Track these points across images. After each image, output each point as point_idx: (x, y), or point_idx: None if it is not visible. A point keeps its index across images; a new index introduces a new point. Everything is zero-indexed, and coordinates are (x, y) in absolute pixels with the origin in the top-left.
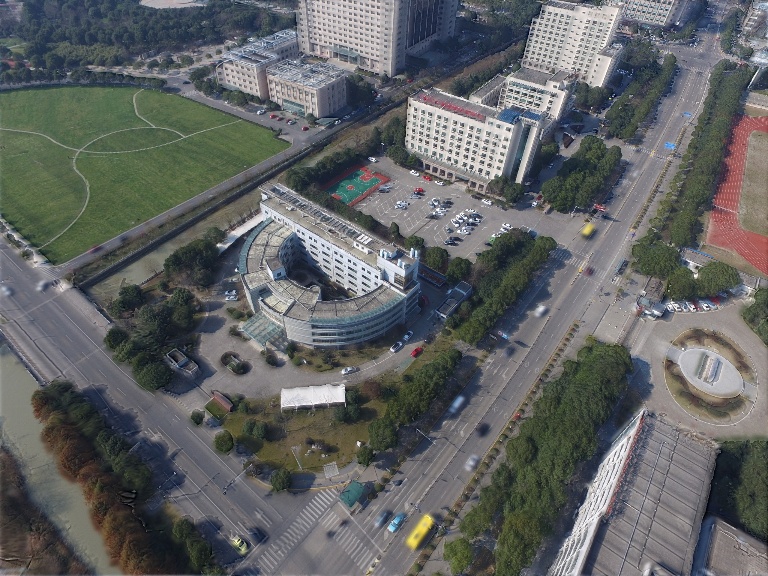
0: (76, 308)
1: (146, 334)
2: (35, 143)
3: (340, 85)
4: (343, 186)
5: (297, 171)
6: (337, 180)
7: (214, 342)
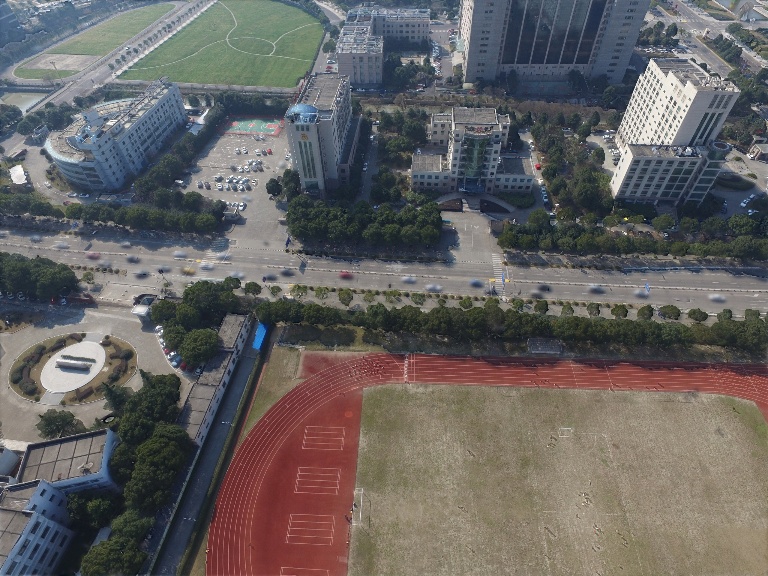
0: None
1: (47, 111)
2: (226, 28)
3: (373, 60)
4: (252, 122)
5: (228, 92)
6: (258, 117)
7: None
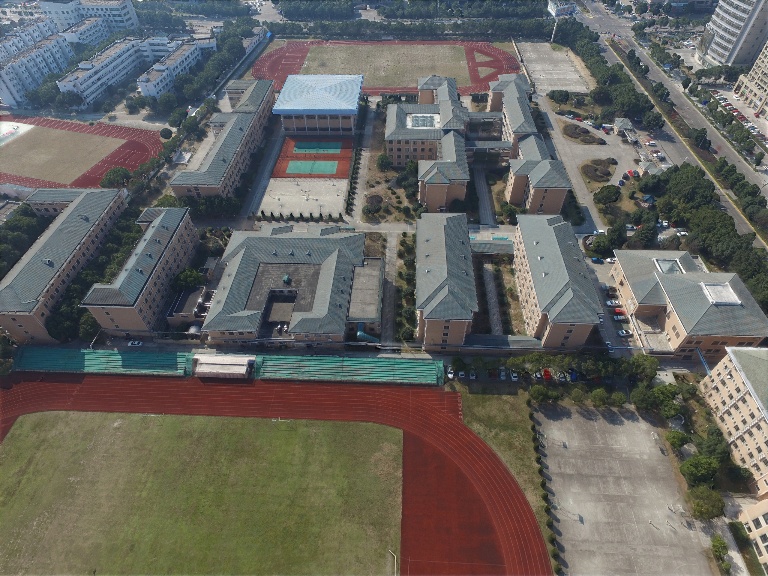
0: None
1: None
2: None
3: None
4: None
5: None
6: None
7: None
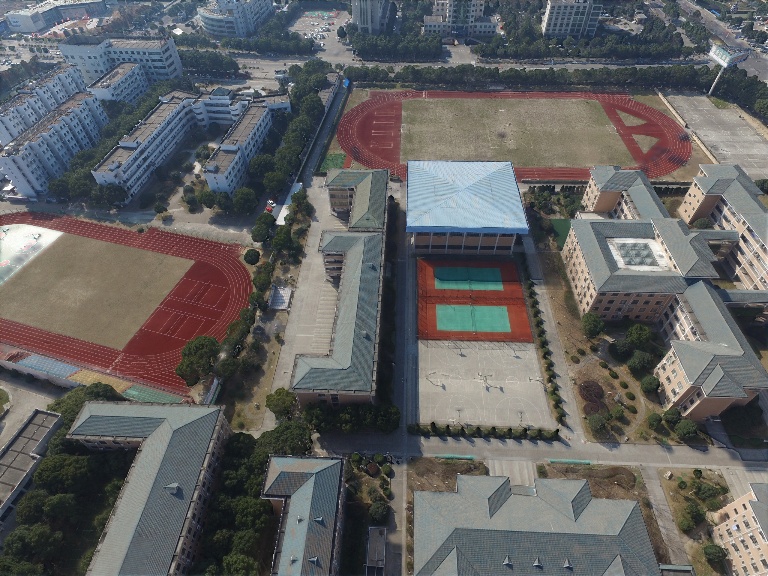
0: None
1: (184, 3)
2: None
3: None
4: None
5: None
6: (321, 9)
7: None
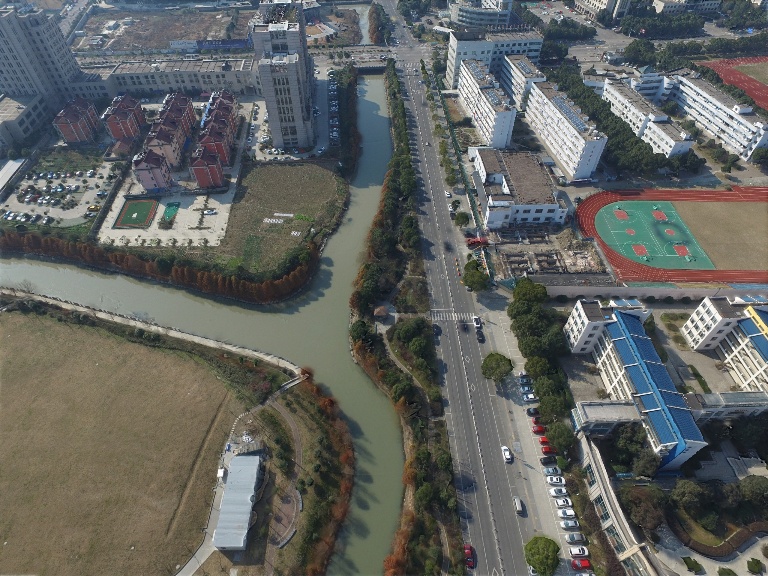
0: (394, 1)
1: (409, 3)
2: None
3: None
4: (526, 3)
5: None
6: (526, 1)
7: None
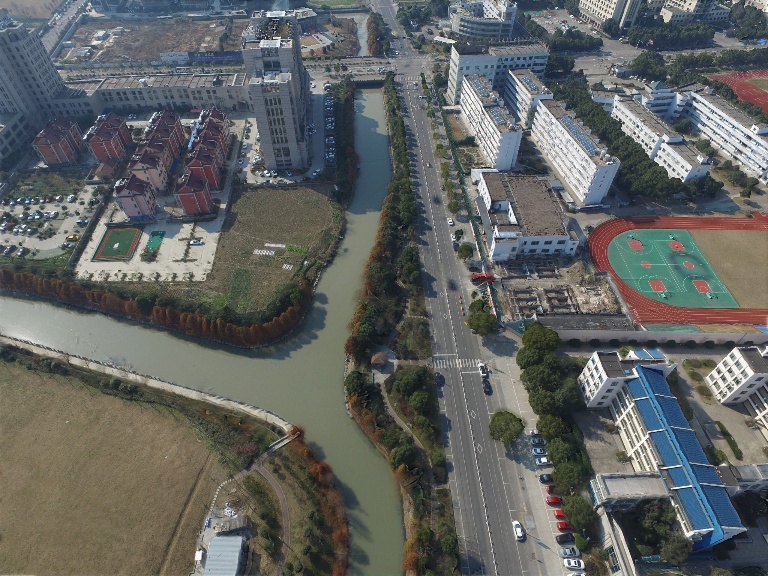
0: None
1: (409, 12)
2: None
3: None
4: (529, 12)
5: None
6: (529, 10)
7: (428, 27)
